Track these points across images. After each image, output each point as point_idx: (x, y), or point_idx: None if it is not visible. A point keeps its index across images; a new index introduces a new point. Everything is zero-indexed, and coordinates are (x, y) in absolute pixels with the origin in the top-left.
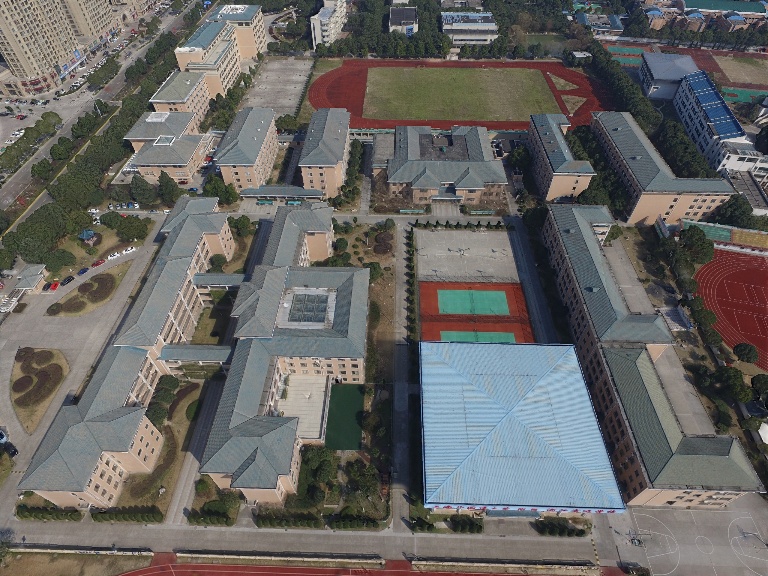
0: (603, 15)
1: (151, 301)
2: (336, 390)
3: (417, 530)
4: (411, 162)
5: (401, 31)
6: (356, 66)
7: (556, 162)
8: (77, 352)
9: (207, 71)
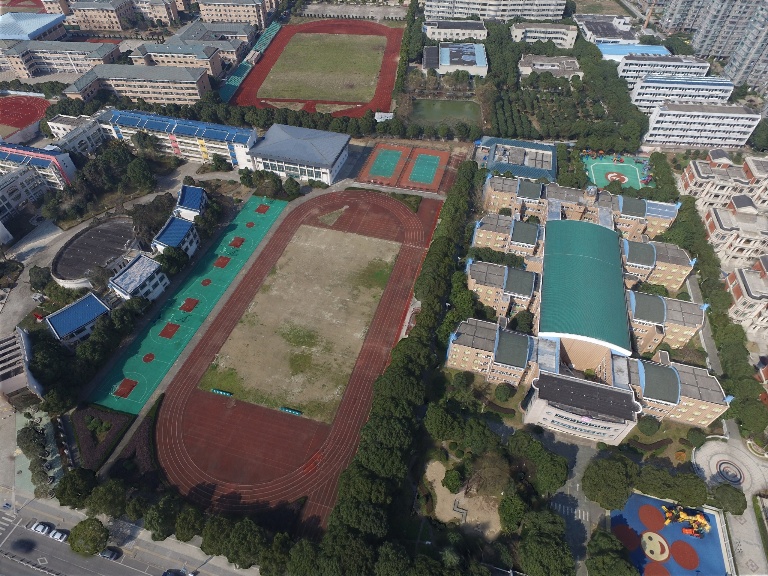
0: (552, 166)
1: None
2: None
3: None
4: (196, 21)
5: None
6: (390, 32)
7: None
8: None
9: None
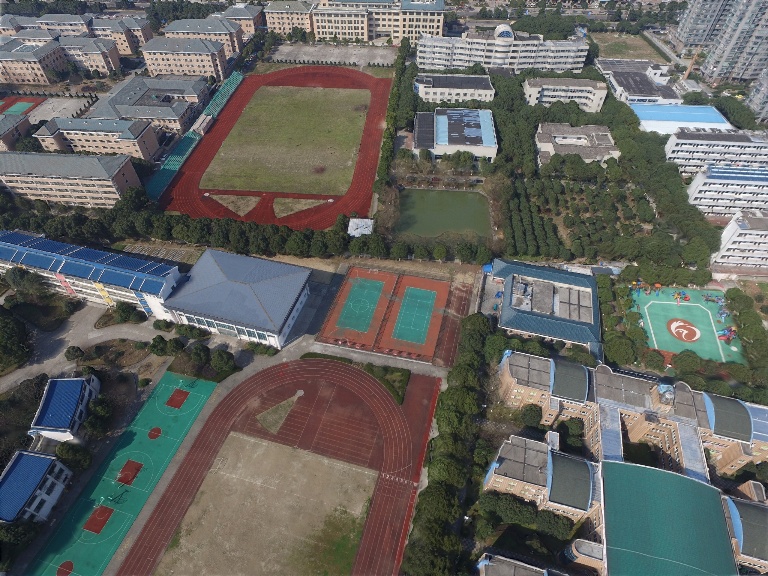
0: (594, 316)
1: (56, 15)
2: None
3: None
4: None
5: None
6: (375, 84)
7: None
8: None
9: None
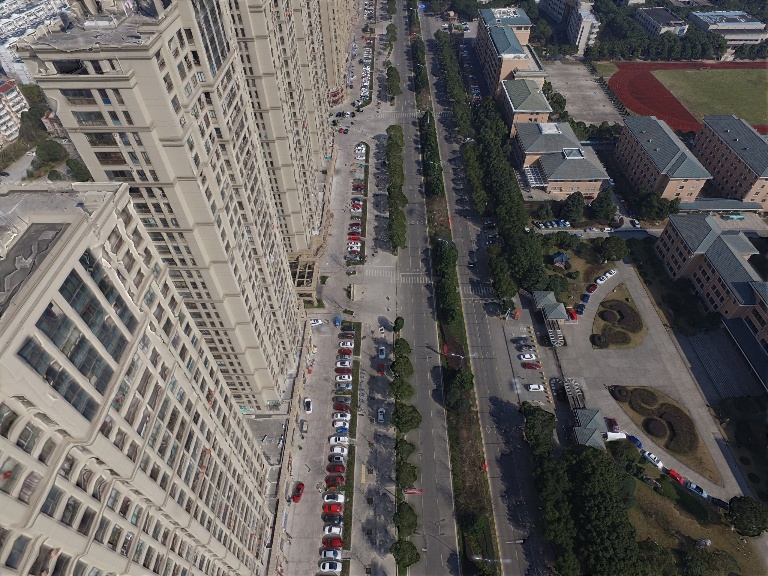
0: None
1: None
2: None
3: None
4: None
5: (673, 32)
6: (635, 69)
7: None
8: (674, 389)
9: (534, 78)
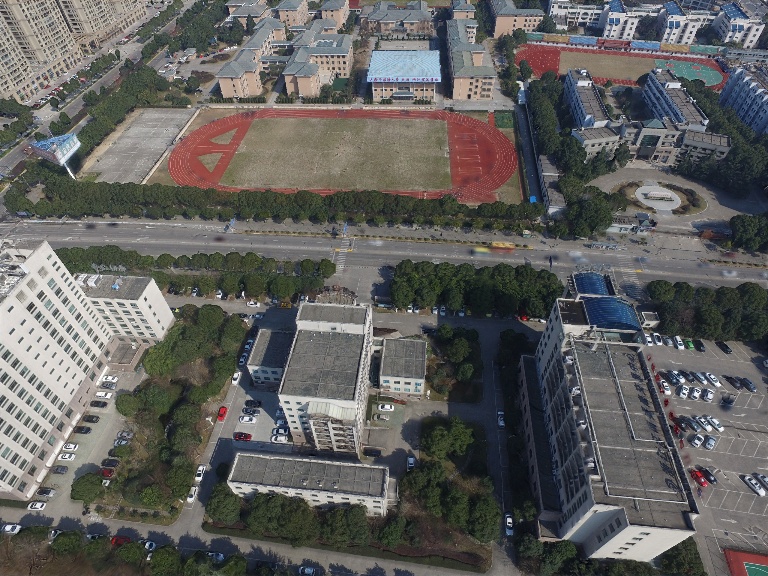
0: None
1: (257, 36)
2: (336, 79)
3: (366, 103)
4: (380, 10)
5: None
6: None
7: (456, 6)
8: None
9: None
